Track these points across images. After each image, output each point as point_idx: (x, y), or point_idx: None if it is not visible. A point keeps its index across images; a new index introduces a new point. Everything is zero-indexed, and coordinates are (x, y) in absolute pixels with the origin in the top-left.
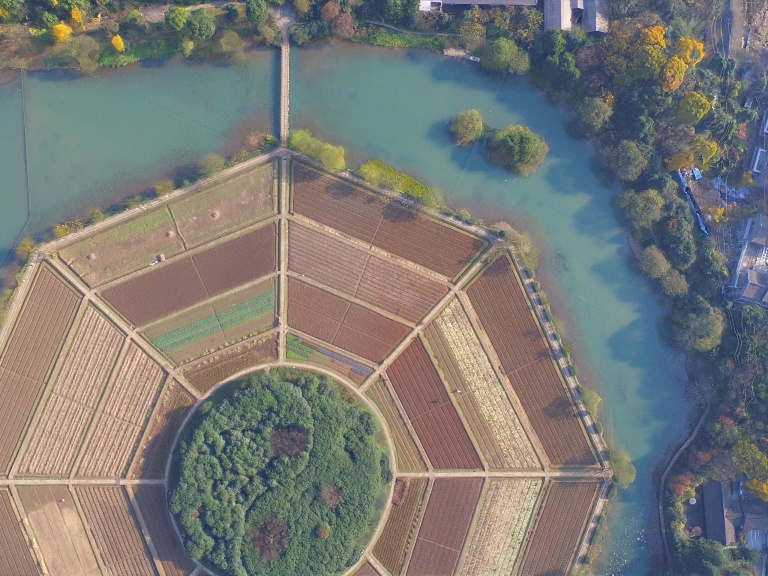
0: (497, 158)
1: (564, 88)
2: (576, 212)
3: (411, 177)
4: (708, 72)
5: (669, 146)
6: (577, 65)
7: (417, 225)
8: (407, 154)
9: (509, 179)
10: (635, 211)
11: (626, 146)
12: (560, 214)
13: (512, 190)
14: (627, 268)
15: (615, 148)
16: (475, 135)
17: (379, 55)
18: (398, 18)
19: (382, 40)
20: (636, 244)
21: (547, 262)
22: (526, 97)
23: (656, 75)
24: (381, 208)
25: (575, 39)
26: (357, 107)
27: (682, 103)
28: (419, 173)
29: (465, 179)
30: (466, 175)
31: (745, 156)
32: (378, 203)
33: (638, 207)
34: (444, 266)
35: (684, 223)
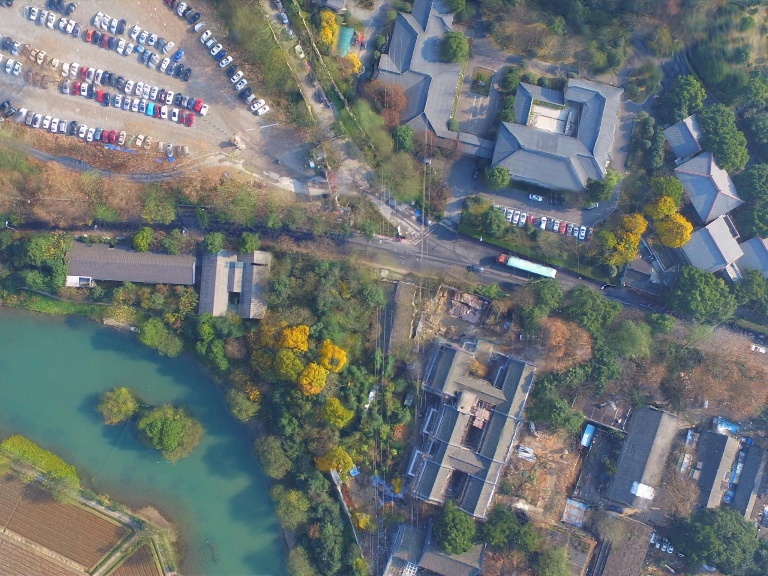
0: (145, 442)
1: (217, 374)
2: (231, 499)
3: (56, 455)
4: (362, 370)
5: (313, 449)
6: (225, 355)
7: (56, 508)
8: (55, 429)
9: (162, 460)
10: (278, 513)
11: (271, 444)
12: (214, 500)
13: (165, 472)
14: (280, 562)
15: (264, 442)
16: (123, 416)
17: (34, 321)
18: (46, 291)
19: (38, 306)
20: (291, 537)
21: (194, 552)
22: (189, 372)
23: (294, 380)
24: (19, 488)
25: (221, 330)
26: (6, 376)
27: (323, 409)
28: (65, 451)
29: (116, 458)
30: (116, 454)
31: (401, 457)
32: (17, 483)
33: (280, 509)
34: (81, 554)
35: (326, 531)
